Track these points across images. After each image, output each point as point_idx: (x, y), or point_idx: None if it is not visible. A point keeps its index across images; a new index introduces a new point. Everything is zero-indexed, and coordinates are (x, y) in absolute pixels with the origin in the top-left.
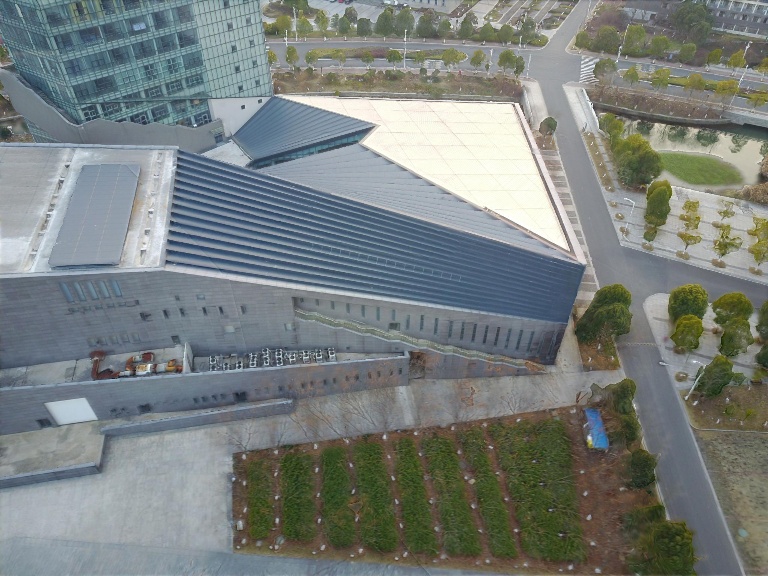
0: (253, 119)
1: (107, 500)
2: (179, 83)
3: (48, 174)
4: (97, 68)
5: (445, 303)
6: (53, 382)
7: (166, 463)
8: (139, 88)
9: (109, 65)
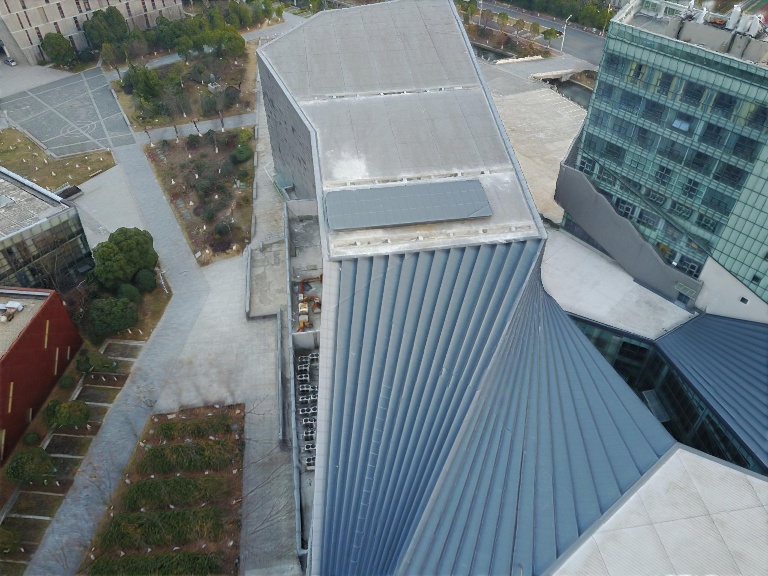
0: (743, 323)
1: (223, 329)
2: (691, 211)
3: (463, 165)
4: (617, 133)
5: (322, 575)
6: (303, 261)
7: (247, 358)
8: (642, 180)
9: (629, 138)
